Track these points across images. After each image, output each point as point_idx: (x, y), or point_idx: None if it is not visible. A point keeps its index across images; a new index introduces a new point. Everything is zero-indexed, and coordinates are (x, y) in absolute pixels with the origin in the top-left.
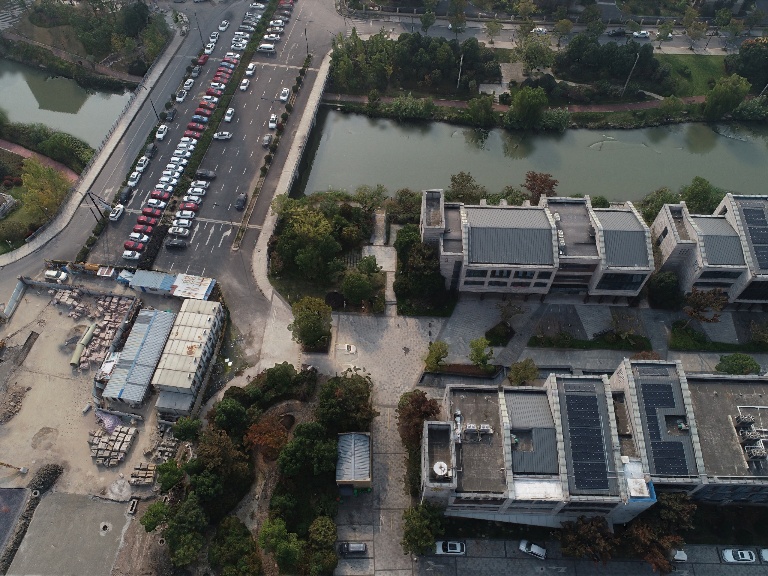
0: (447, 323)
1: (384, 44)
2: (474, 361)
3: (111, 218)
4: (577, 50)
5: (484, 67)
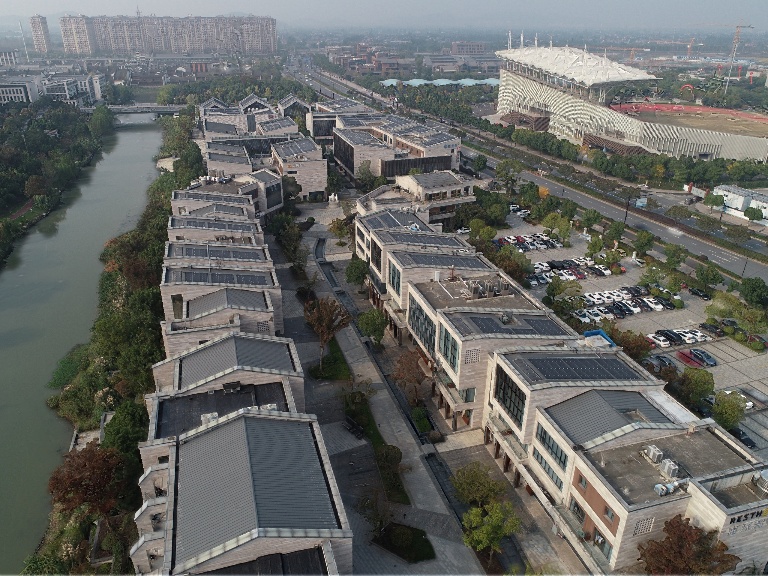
0: None
1: None
2: (515, 529)
3: None
4: None
5: None
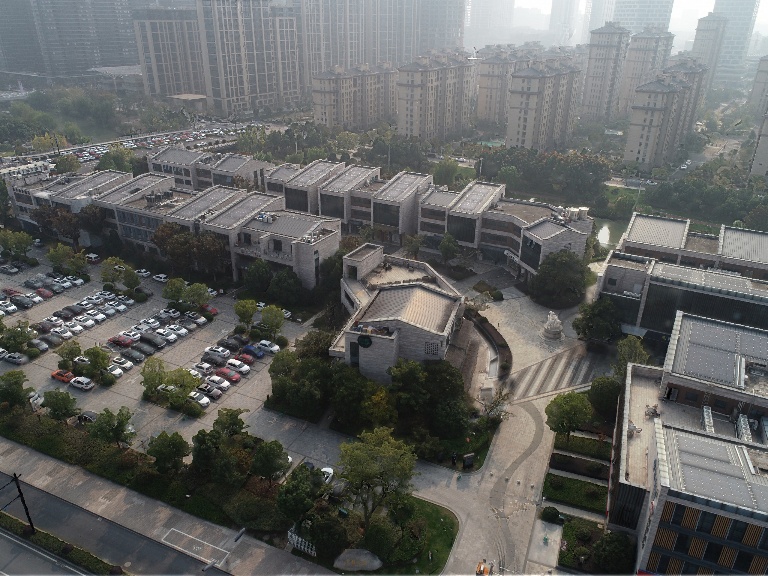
0: None
1: (271, 133)
2: None
3: (62, 154)
4: None
5: None
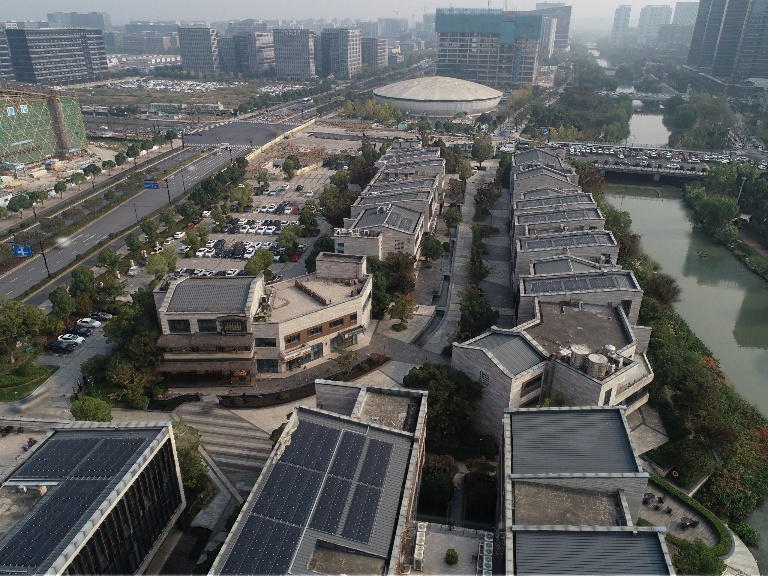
0: None
1: None
2: None
3: None
4: None
5: (764, 203)
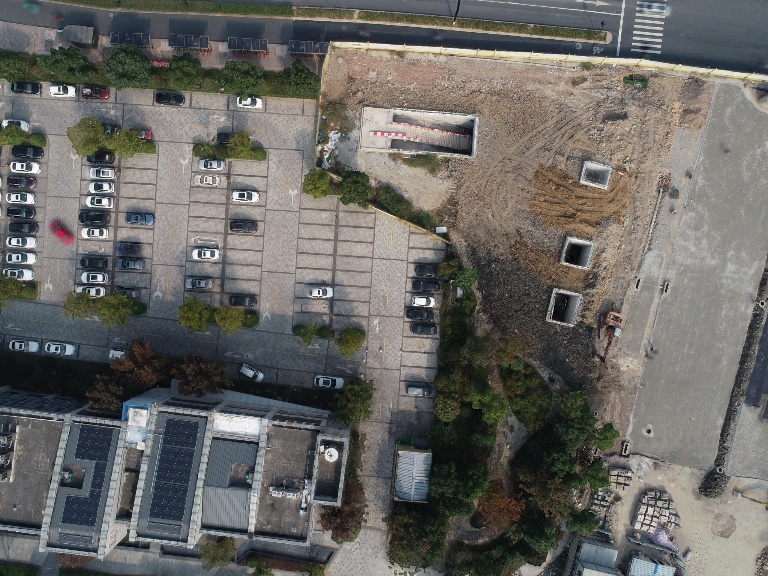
0: None
1: None
2: None
3: None
4: None
5: None
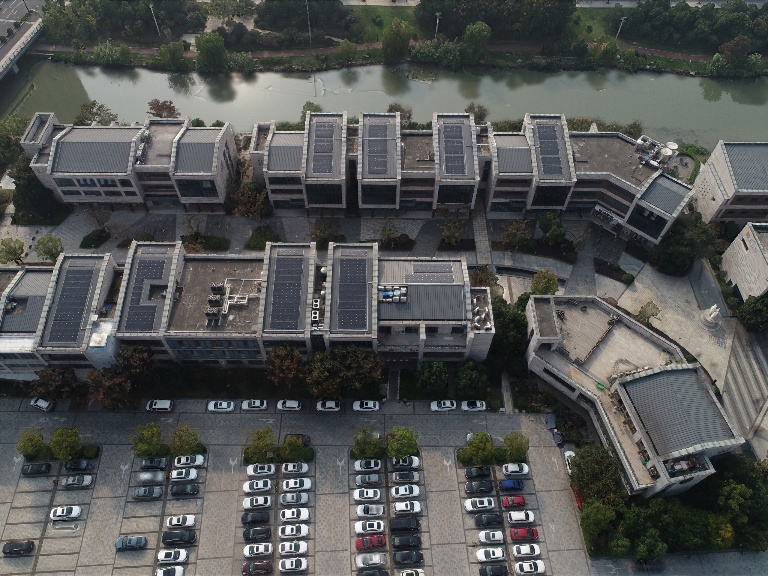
0: (54, 230)
1: None
2: None
3: None
4: (271, 1)
5: (184, 18)
